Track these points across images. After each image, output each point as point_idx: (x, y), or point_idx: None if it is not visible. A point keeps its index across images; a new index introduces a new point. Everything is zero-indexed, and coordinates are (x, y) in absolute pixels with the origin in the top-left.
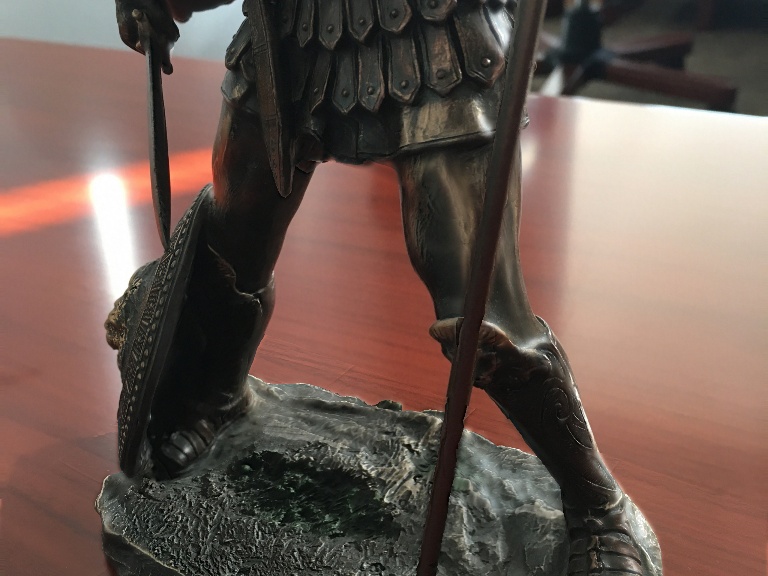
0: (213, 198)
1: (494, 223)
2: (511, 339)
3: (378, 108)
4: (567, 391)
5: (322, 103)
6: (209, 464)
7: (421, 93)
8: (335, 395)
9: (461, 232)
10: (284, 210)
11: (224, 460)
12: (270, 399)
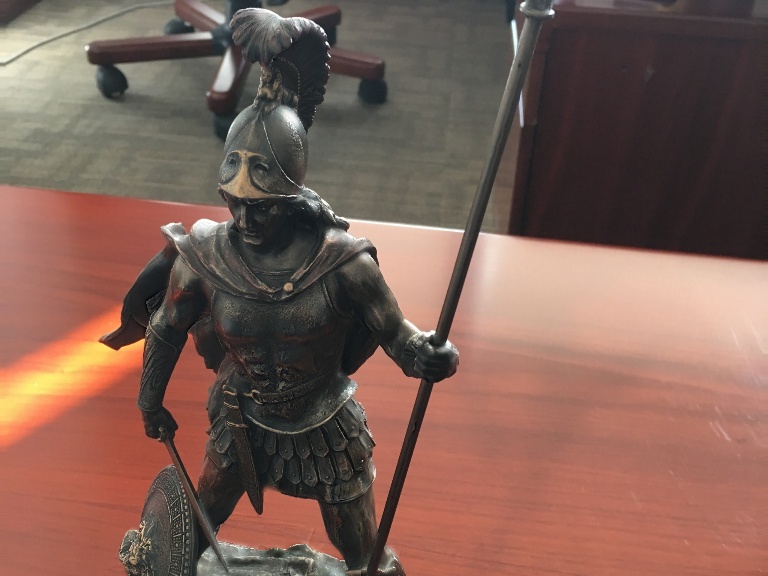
0: None
1: (382, 546)
2: (381, 568)
3: (315, 486)
4: (401, 574)
5: (282, 479)
6: None
7: (336, 481)
8: (240, 549)
9: (357, 532)
10: (238, 497)
11: None
12: (204, 563)
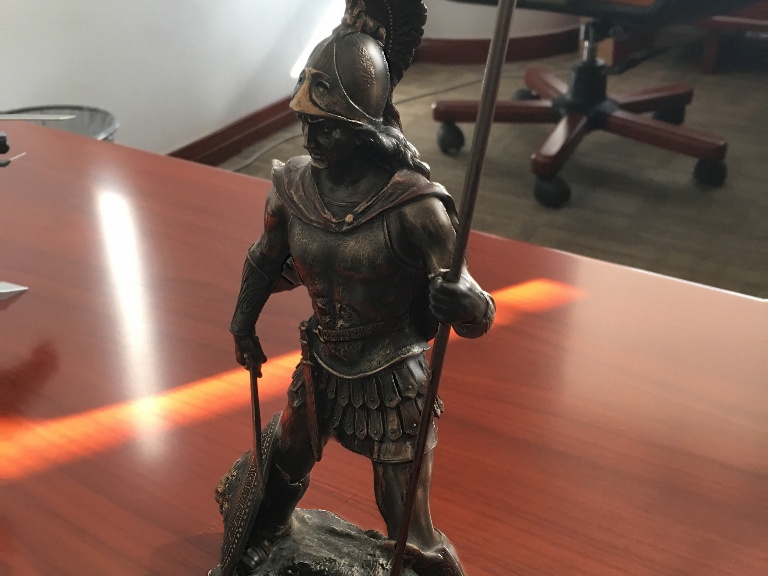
0: (280, 439)
1: (409, 514)
2: (422, 549)
3: (363, 439)
4: (452, 569)
5: (338, 426)
6: (268, 567)
7: (383, 438)
8: (343, 522)
9: (400, 500)
10: None
11: (277, 565)
12: (304, 524)
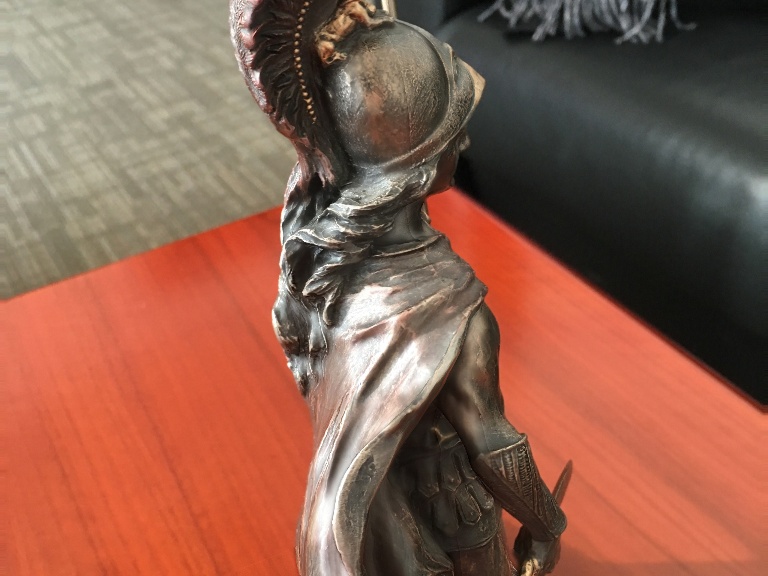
0: None
1: None
2: None
3: None
4: None
5: None
6: None
7: None
8: None
9: None
10: None
11: None
12: None
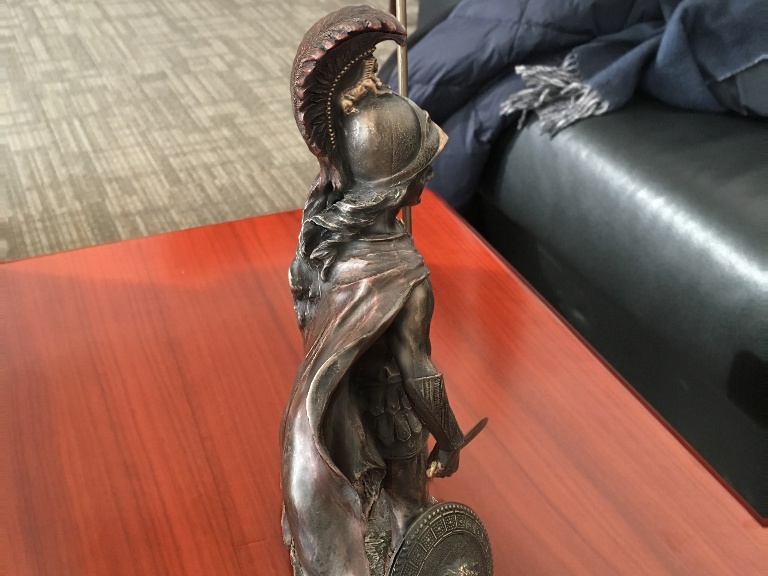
0: None
1: None
2: None
3: None
4: None
5: None
6: None
7: None
8: None
9: None
10: None
11: None
12: None
